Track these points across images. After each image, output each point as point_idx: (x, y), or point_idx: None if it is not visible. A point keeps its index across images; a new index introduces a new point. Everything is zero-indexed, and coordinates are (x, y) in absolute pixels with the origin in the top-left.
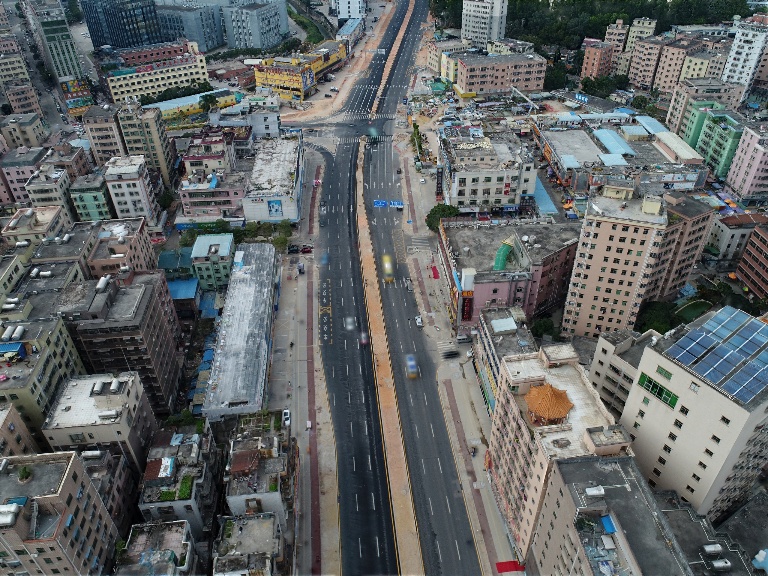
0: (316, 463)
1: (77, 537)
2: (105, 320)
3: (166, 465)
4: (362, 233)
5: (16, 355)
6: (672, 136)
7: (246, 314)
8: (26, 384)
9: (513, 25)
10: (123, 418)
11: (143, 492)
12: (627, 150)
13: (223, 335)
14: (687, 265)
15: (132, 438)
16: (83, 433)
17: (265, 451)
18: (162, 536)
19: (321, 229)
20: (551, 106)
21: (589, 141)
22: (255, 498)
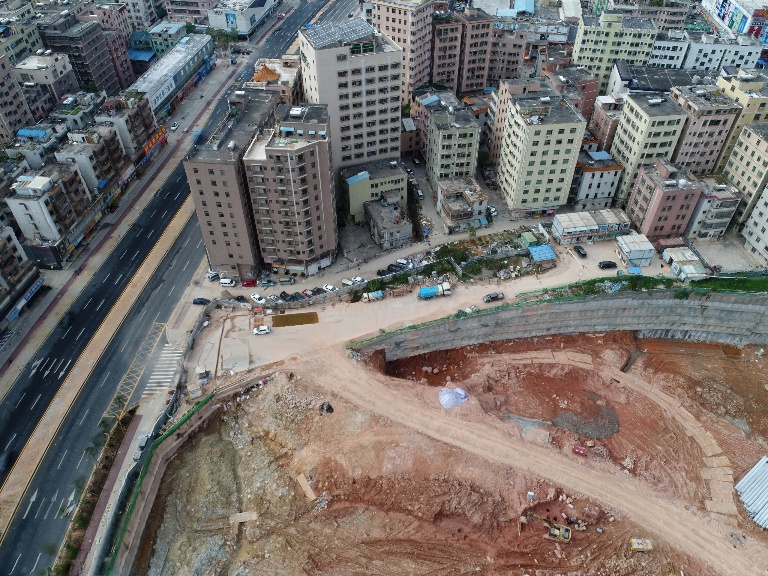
0: (178, 146)
1: (1, 96)
2: (62, 33)
3: (69, 100)
4: (292, 47)
5: (3, 33)
6: (574, 2)
7: (169, 66)
8: (2, 44)
9: None
10: (49, 70)
11: (54, 111)
12: (528, 9)
13: (148, 73)
14: (479, 67)
15: (57, 87)
16: (28, 74)
17: (124, 102)
18: (55, 126)
19: (266, 43)
20: None
21: (507, 2)
22: (110, 121)
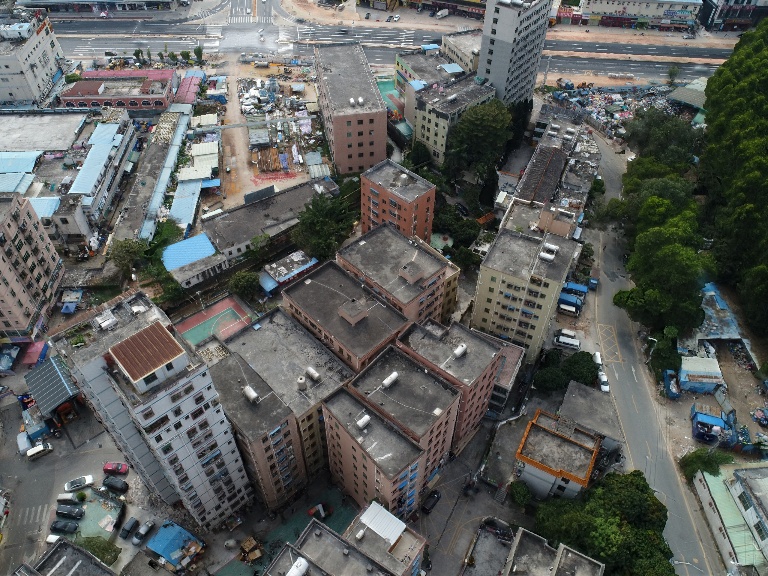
0: None
1: None
2: None
3: None
4: None
5: None
6: None
7: None
8: None
9: (641, 115)
10: None
11: None
12: None
13: None
14: None
15: None
16: None
17: None
18: None
19: None
20: (282, 179)
21: (23, 147)
22: None
